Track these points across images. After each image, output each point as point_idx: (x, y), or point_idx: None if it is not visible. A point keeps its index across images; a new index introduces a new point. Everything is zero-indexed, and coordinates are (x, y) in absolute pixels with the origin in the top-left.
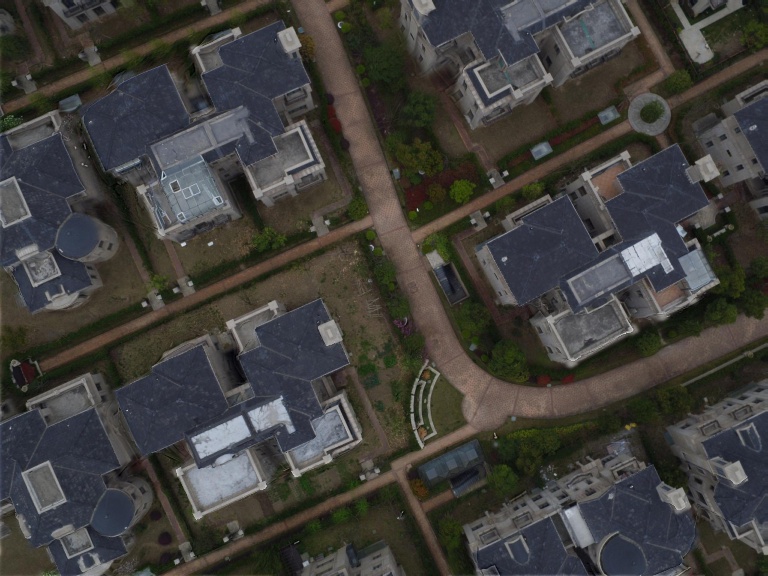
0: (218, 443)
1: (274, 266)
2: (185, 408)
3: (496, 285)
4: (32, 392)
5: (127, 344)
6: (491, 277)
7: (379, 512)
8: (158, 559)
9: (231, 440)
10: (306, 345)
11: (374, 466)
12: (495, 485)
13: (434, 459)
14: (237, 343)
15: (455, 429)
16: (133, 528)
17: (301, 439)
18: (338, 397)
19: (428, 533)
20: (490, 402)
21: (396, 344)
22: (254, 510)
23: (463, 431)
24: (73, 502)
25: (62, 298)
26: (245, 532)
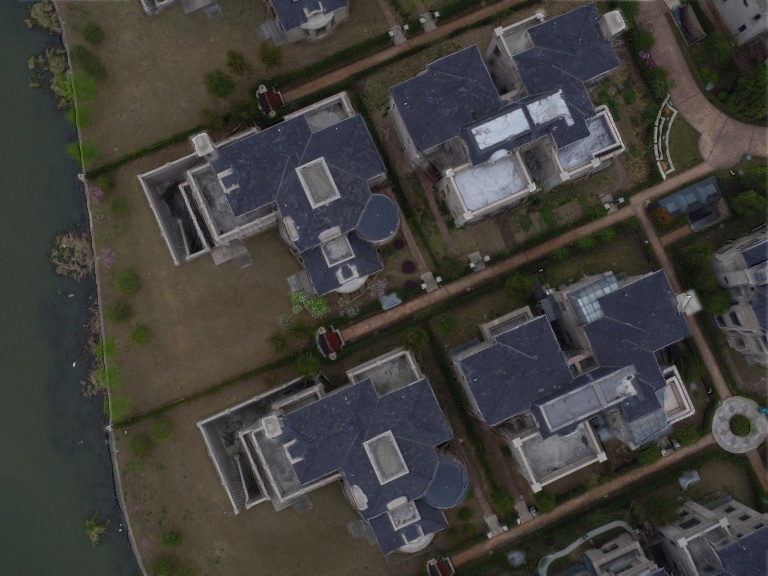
0: (498, 135)
1: (515, 3)
2: (466, 99)
3: (739, 19)
4: (284, 113)
5: (370, 76)
6: (732, 13)
7: (622, 242)
8: (402, 287)
9: (510, 132)
10: (585, 40)
11: (615, 199)
12: (738, 214)
13: (673, 194)
14: (505, 50)
15: (692, 166)
16: (384, 248)
17: (577, 134)
18: (602, 107)
19: (666, 267)
20: (726, 141)
21: (635, 81)
22: (496, 241)
23: (700, 168)
24: (345, 200)
25: (317, 18)
26: (488, 262)
